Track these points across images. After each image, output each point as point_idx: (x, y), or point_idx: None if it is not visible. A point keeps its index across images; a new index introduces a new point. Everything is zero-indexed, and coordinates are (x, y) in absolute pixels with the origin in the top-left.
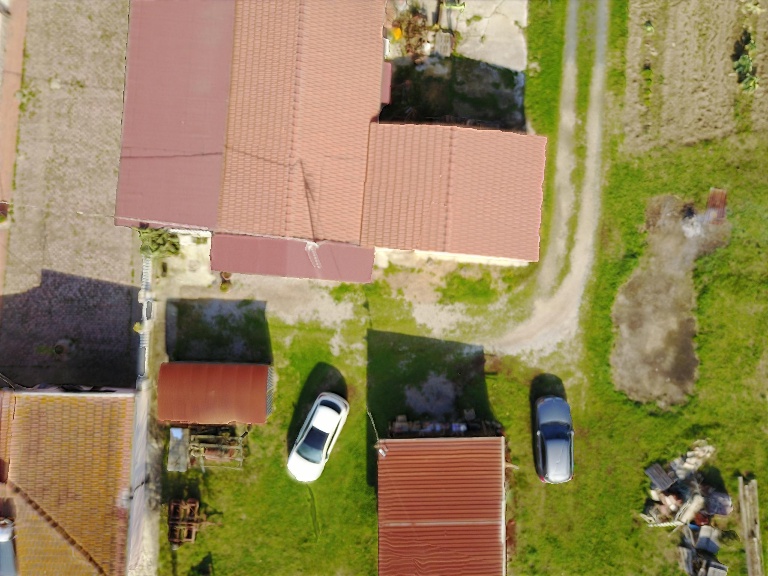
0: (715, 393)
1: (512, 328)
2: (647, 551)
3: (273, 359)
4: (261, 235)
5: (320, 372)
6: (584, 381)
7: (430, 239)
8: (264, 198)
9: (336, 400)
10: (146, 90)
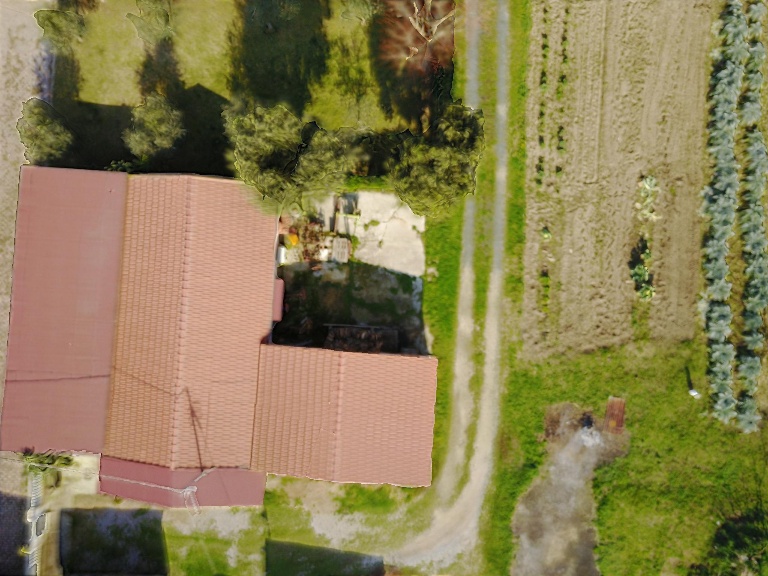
0: None
1: (412, 538)
2: None
3: (170, 570)
4: (138, 482)
5: None
6: None
7: (319, 466)
8: (151, 425)
9: None
10: (33, 311)
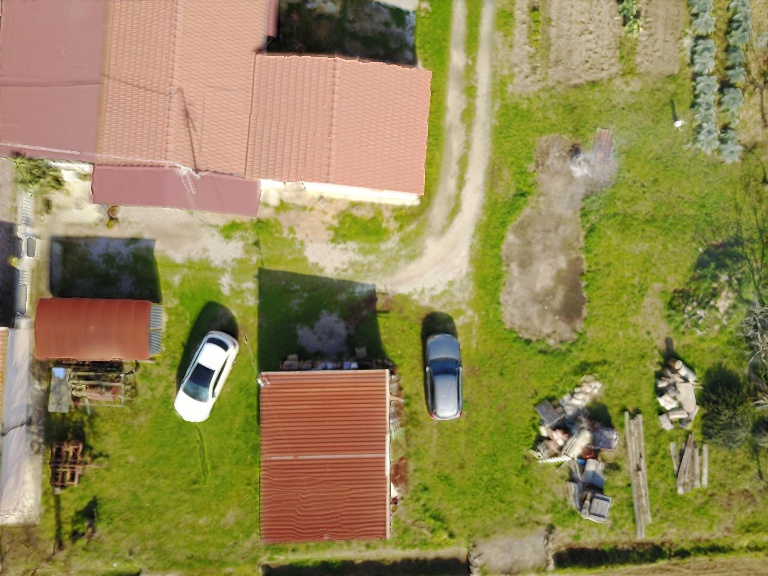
0: (602, 330)
1: (404, 267)
2: (536, 487)
3: (162, 299)
4: (133, 159)
5: (210, 312)
6: (475, 319)
7: (314, 171)
8: (145, 128)
9: (224, 338)
10: (24, 18)
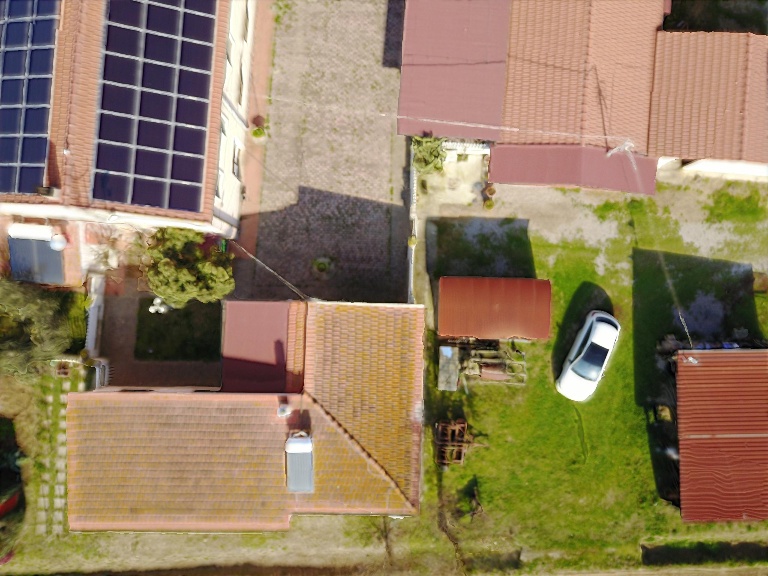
0: None
1: None
2: None
3: None
4: (579, 135)
5: (585, 291)
6: None
7: (724, 147)
8: (554, 106)
9: (610, 317)
10: None
